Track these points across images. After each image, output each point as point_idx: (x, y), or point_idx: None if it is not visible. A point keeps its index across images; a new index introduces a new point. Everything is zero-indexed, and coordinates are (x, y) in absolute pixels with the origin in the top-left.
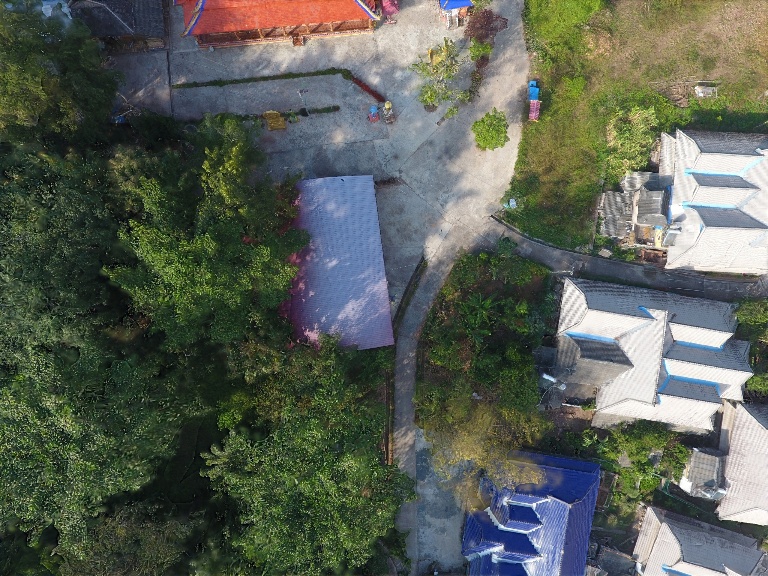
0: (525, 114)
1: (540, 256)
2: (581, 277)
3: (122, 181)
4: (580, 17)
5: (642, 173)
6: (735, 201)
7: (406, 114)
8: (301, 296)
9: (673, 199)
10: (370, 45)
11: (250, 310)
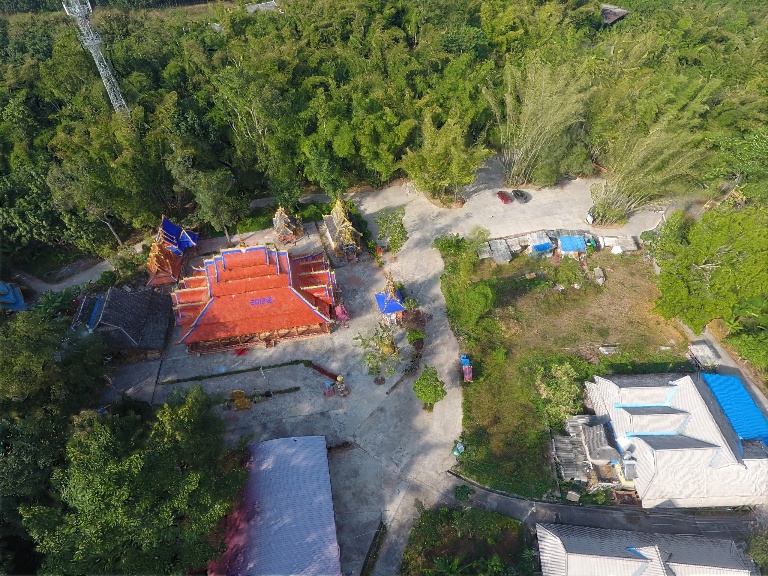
0: (462, 380)
1: (508, 510)
2: None
3: (78, 432)
4: (483, 305)
5: (581, 416)
6: (674, 427)
7: (358, 388)
8: (238, 571)
9: (616, 433)
10: (328, 343)
11: (169, 572)
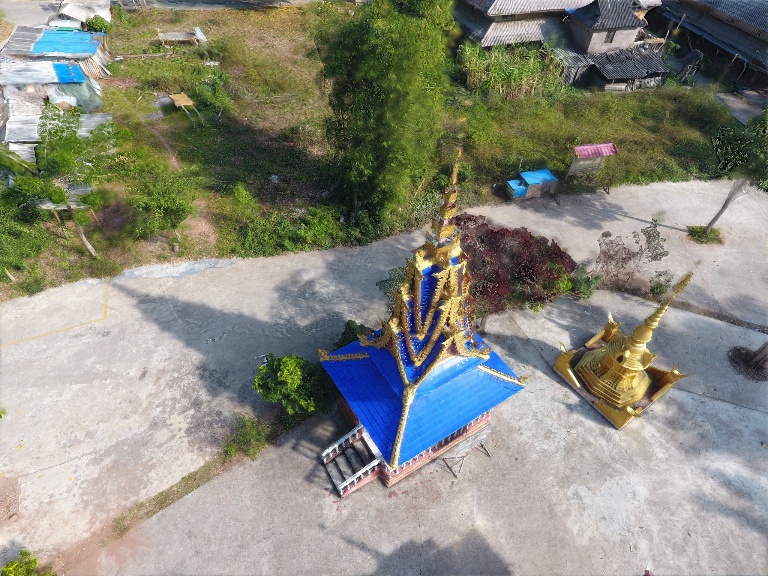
0: (576, 190)
1: None
2: (737, 89)
3: None
4: None
5: None
6: None
7: None
8: None
9: None
10: None
11: None
